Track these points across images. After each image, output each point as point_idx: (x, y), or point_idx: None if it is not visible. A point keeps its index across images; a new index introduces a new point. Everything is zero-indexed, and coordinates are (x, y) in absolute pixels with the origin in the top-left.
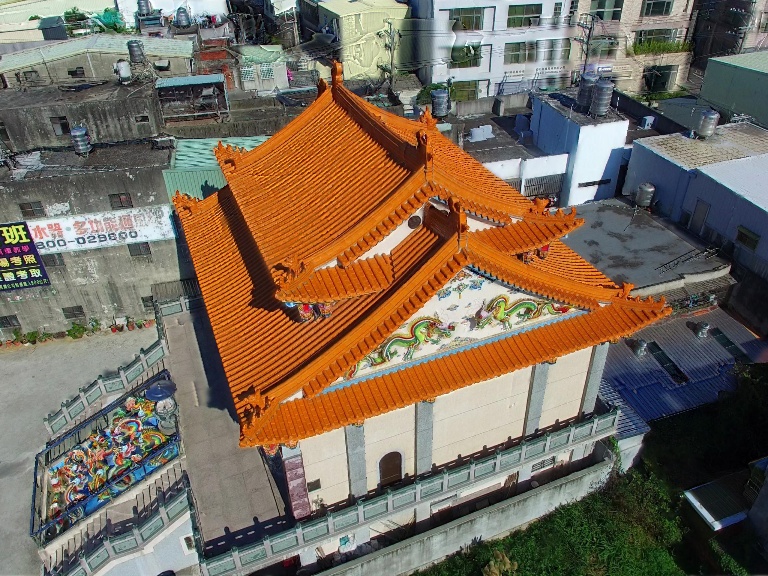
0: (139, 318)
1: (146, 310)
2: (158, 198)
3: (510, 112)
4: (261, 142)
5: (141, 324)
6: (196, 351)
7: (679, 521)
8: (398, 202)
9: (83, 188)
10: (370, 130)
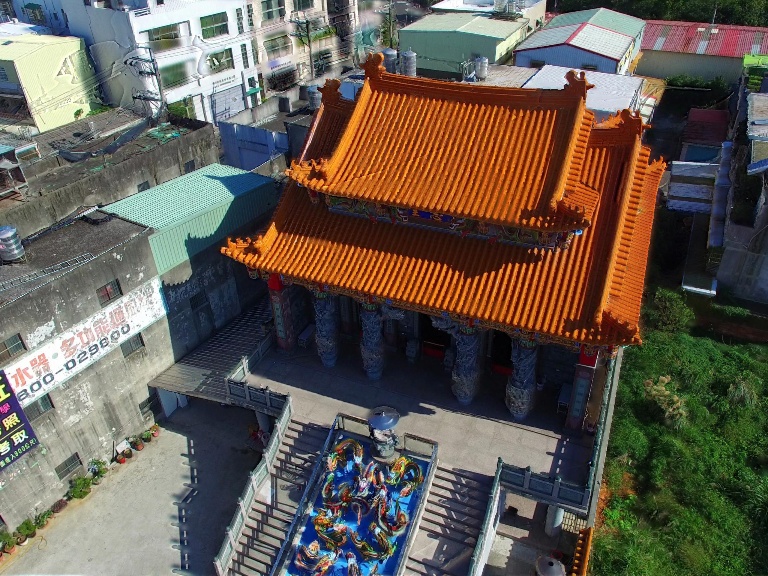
0: (139, 433)
1: (144, 419)
2: (147, 273)
3: (293, 107)
4: (189, 182)
5: (150, 436)
6: (311, 395)
7: (687, 307)
8: (577, 131)
9: (68, 293)
10: (463, 98)
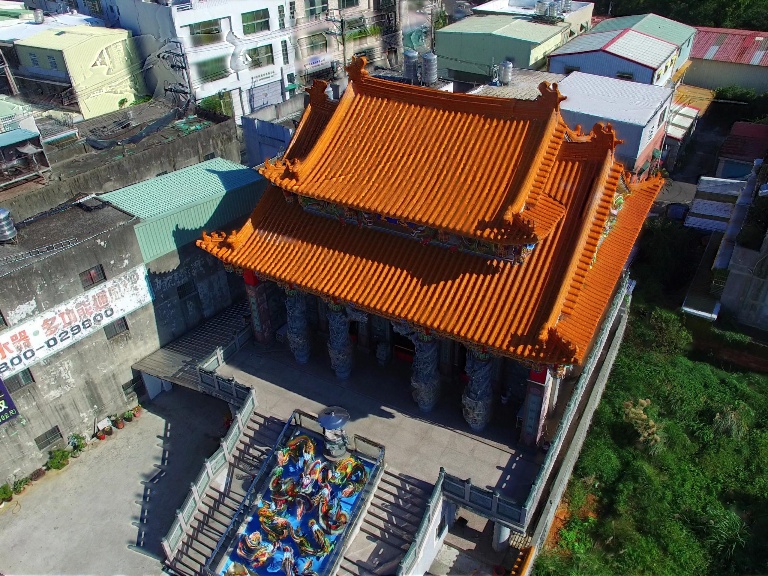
0: (121, 412)
1: (128, 399)
2: (132, 260)
3: None
4: (188, 175)
5: (131, 416)
6: (278, 389)
7: (686, 329)
8: (546, 144)
9: (50, 275)
10: (440, 105)
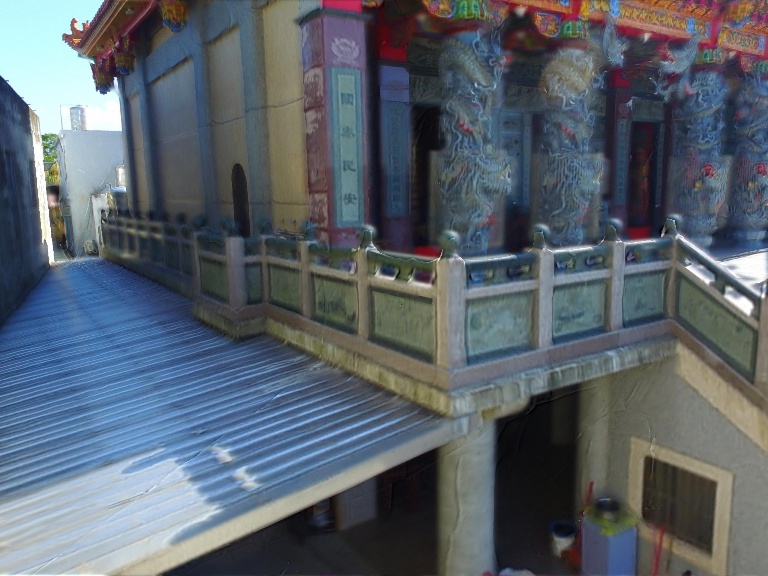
0: None
1: None
2: None
3: None
4: None
5: None
6: None
7: None
8: None
9: None
10: None
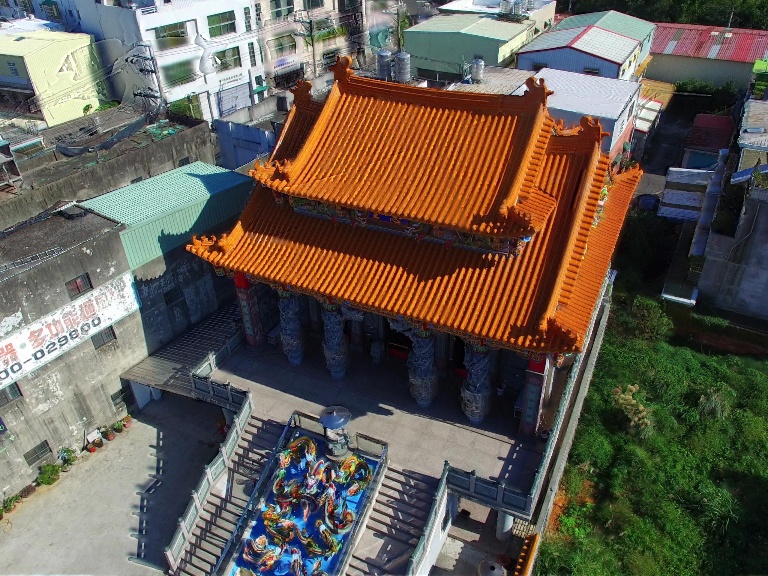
0: (111, 423)
1: (117, 409)
2: (118, 267)
3: None
4: (169, 179)
5: (121, 426)
6: (274, 392)
7: (666, 316)
8: (535, 138)
9: (35, 286)
10: (428, 102)
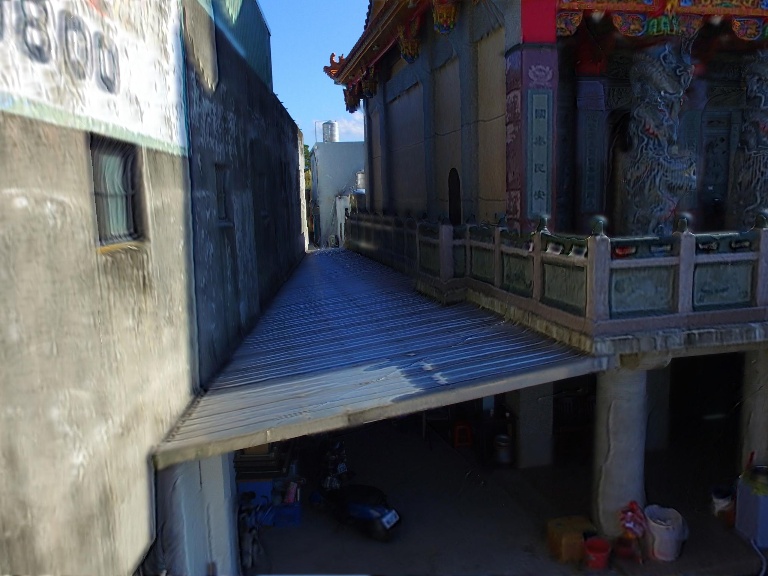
0: None
1: None
2: None
3: None
4: None
5: None
6: None
7: None
8: None
9: None
10: None
